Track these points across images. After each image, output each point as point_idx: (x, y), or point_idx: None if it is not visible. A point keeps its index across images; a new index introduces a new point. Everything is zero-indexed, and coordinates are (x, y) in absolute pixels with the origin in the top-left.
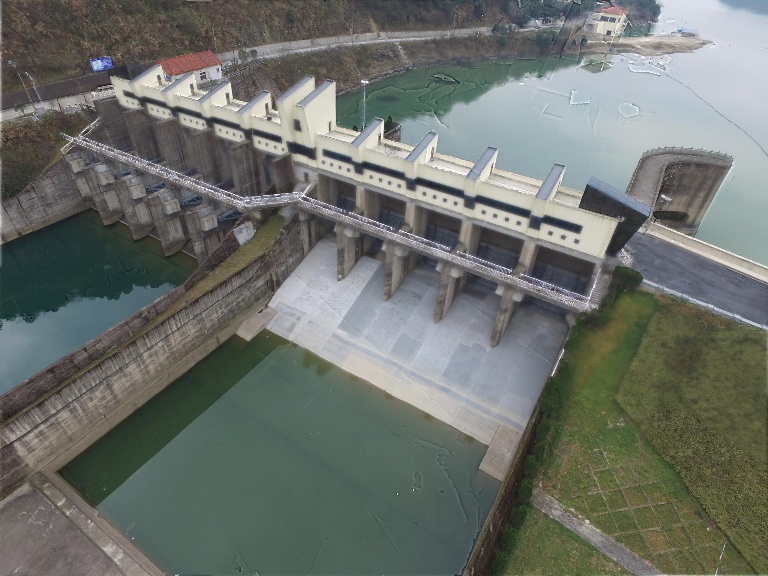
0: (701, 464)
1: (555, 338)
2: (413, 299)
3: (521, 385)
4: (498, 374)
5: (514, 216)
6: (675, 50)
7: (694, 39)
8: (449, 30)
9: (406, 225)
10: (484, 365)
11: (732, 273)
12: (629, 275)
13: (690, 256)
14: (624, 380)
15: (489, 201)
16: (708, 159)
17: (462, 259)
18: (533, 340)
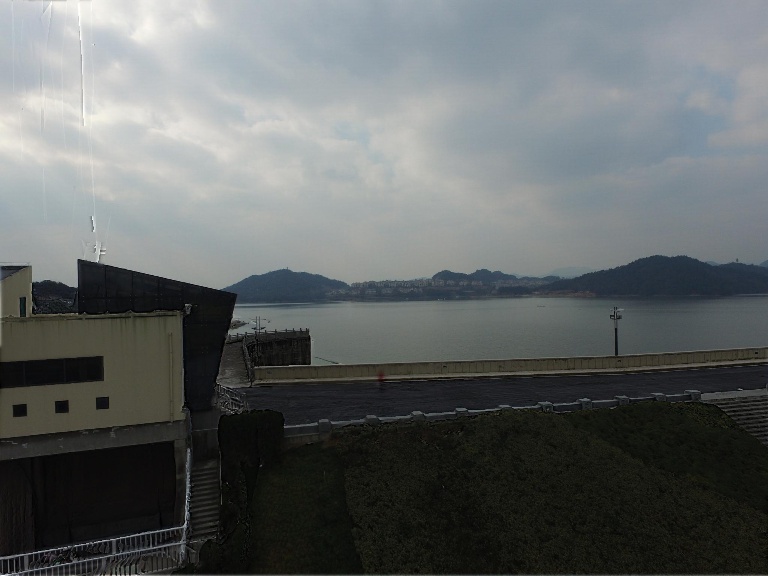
0: None
1: None
2: None
3: None
4: None
5: None
6: None
7: None
8: None
9: None
10: None
11: (395, 383)
12: (253, 422)
13: (332, 386)
14: None
15: None
16: (285, 333)
17: None
18: None
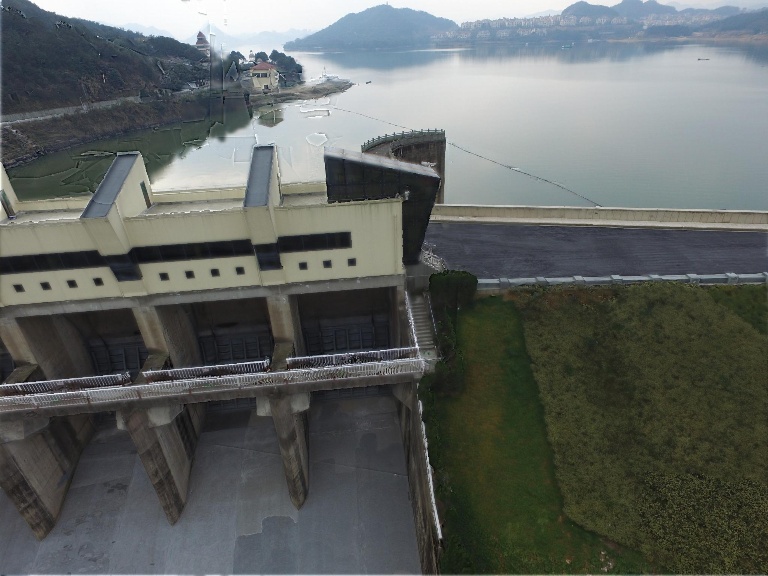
0: (765, 561)
1: (387, 429)
2: (109, 498)
3: (380, 552)
4: (333, 557)
5: (225, 261)
6: (329, 92)
7: (339, 80)
8: (82, 103)
9: (20, 365)
10: (300, 555)
11: (549, 229)
12: (456, 282)
13: (493, 228)
14: (559, 470)
15: (163, 251)
16: (423, 137)
17: (158, 385)
18: (358, 452)
